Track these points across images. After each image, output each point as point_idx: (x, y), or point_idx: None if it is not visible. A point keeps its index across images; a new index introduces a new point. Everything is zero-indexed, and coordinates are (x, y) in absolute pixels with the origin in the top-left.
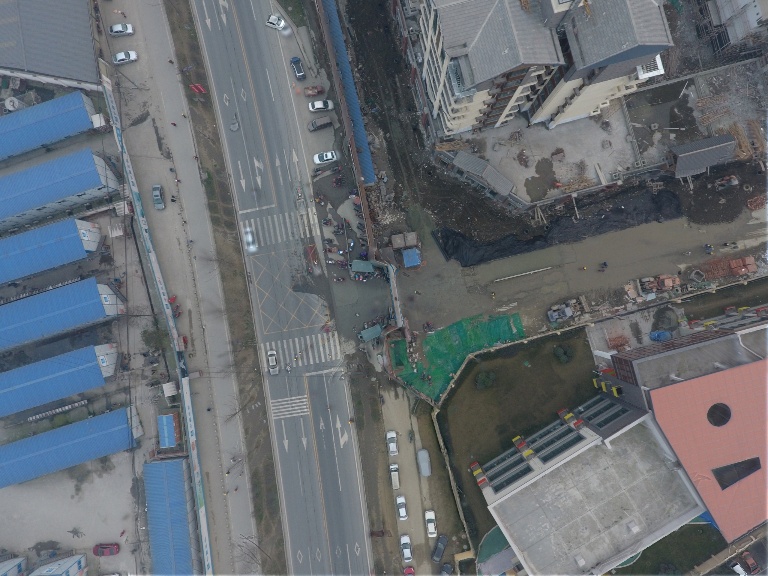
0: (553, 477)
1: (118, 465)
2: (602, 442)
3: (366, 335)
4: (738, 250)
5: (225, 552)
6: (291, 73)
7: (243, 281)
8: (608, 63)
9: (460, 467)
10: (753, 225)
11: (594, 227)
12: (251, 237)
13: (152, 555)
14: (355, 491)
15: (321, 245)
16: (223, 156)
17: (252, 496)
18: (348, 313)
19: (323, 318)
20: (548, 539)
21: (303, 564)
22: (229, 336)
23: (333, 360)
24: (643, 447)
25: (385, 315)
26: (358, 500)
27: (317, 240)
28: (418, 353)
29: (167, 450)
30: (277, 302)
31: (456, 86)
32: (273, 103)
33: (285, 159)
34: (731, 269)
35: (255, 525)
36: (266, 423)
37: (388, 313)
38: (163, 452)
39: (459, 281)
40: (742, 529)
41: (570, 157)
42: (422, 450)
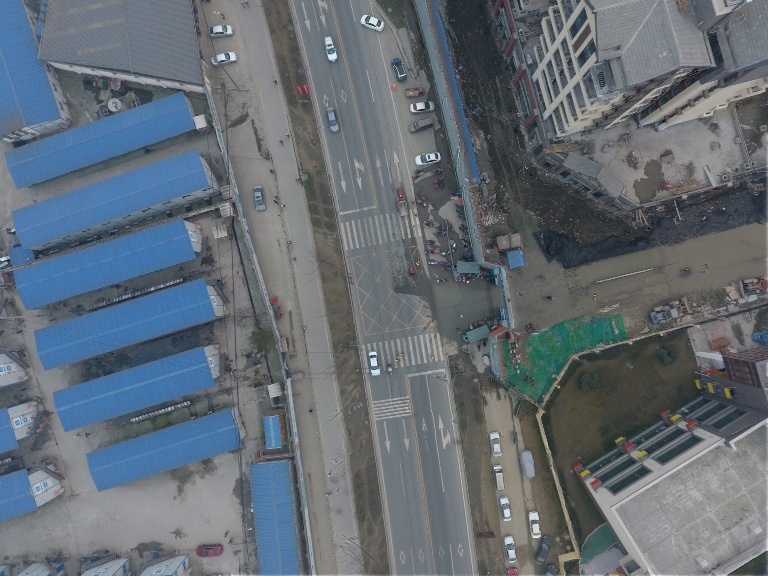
0: (673, 478)
1: (220, 466)
2: (725, 443)
3: (472, 336)
4: None
5: (327, 553)
6: (392, 74)
7: (344, 282)
8: (758, 65)
9: (563, 468)
10: None
11: (695, 228)
12: (351, 238)
13: (259, 556)
14: (458, 492)
15: (423, 246)
16: (323, 157)
17: (354, 497)
18: (451, 314)
19: (425, 319)
20: (669, 540)
21: (406, 565)
22: (330, 337)
23: (437, 361)
24: (763, 448)
25: (495, 316)
26: (461, 501)
27: (419, 241)
28: (520, 354)
29: (274, 451)
30: (378, 303)
31: (598, 88)
32: (373, 104)
33: (386, 160)
34: None
35: (357, 526)
36: (368, 424)
37: (499, 314)
38: (270, 453)
39: (561, 282)
40: None
41: (679, 159)
42: (526, 451)
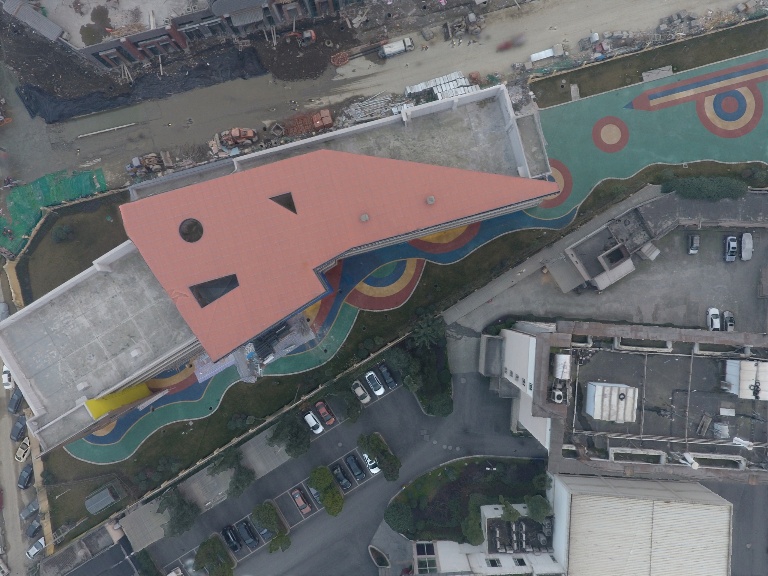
0: (62, 305)
1: None
2: None
3: None
4: (322, 106)
5: None
6: None
7: None
8: None
9: None
10: (338, 81)
11: (179, 84)
12: None
13: None
14: None
15: None
16: None
17: None
18: None
19: None
20: (55, 366)
21: None
22: None
23: None
24: (151, 275)
25: None
26: None
27: None
28: (2, 209)
29: None
30: None
31: None
32: None
33: None
34: (312, 124)
35: None
36: None
37: None
38: None
39: (43, 137)
40: (226, 348)
41: (125, 4)
42: None
